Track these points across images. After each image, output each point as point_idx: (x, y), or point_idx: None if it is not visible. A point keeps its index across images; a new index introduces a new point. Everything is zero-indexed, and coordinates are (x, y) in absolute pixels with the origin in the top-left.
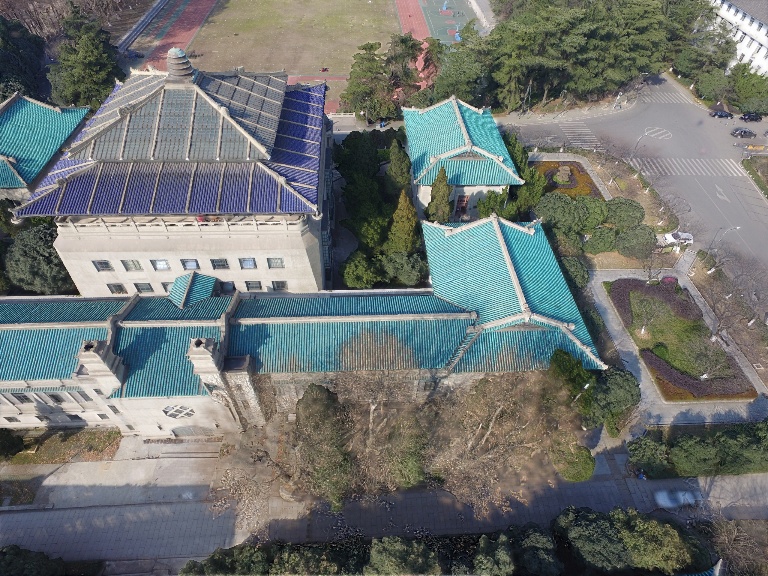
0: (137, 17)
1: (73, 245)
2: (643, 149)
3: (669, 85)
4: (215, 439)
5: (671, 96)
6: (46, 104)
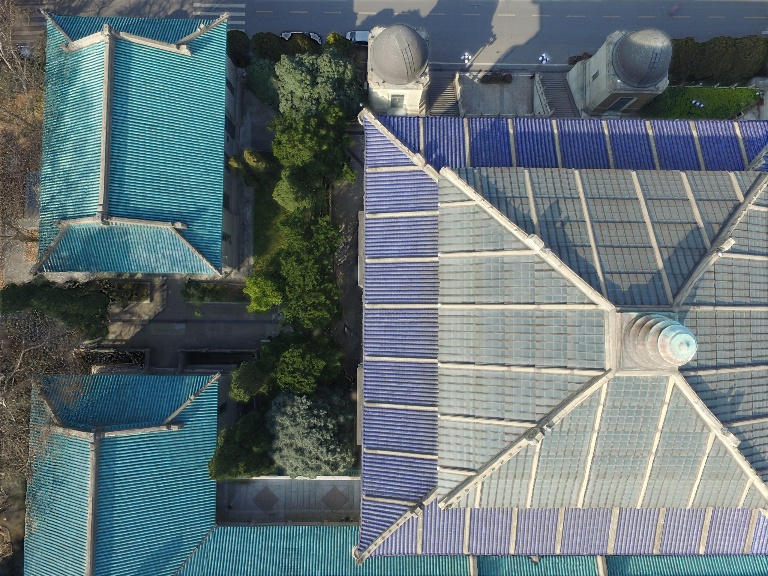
0: None
1: None
2: None
3: None
4: None
5: None
6: (163, 43)
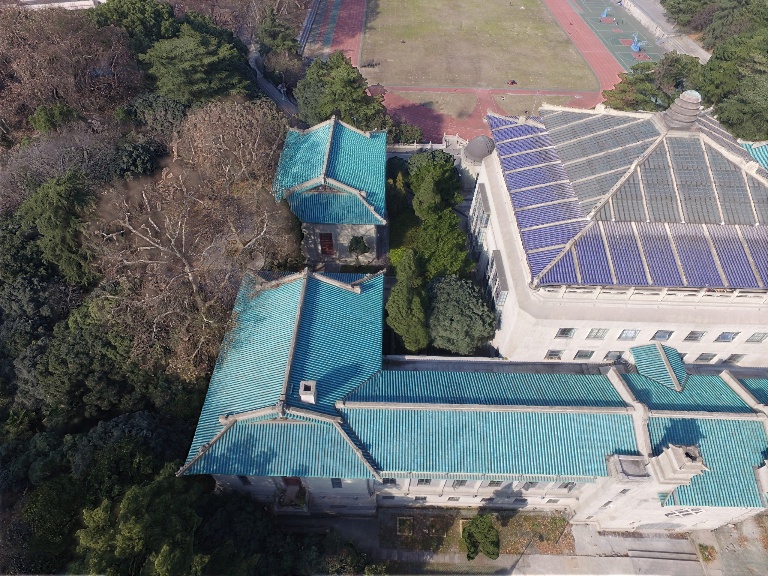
0: None
1: (551, 311)
2: None
3: None
4: (678, 535)
5: None
6: None
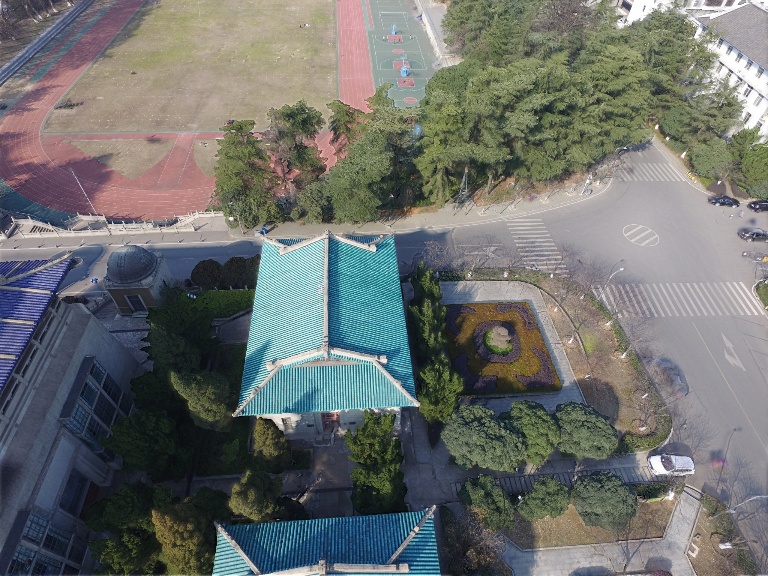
0: (18, 50)
1: None
2: (620, 266)
3: (655, 151)
4: None
5: (657, 169)
6: None
